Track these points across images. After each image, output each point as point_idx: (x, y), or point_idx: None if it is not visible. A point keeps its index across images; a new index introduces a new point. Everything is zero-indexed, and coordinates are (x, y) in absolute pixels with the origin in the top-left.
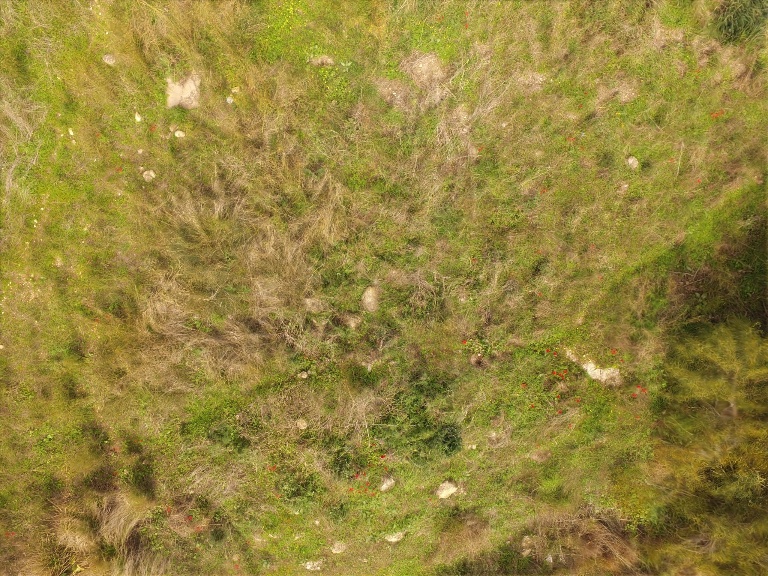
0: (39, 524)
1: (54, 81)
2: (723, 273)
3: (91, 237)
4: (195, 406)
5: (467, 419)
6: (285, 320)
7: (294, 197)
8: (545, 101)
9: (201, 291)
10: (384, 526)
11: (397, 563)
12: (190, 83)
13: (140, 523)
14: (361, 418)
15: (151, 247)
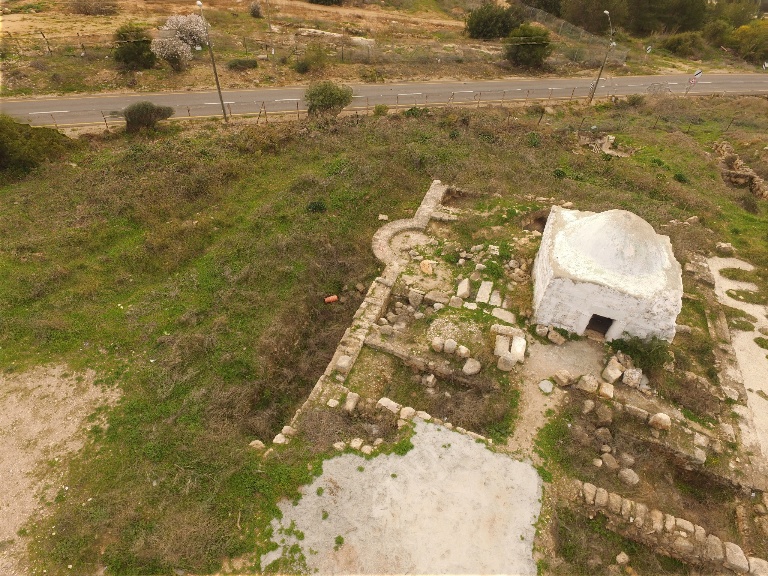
0: None
1: None
2: (7, 180)
3: None
4: None
5: None
6: None
7: None
8: None
9: None
10: None
11: None
12: None
13: None
14: None
15: None
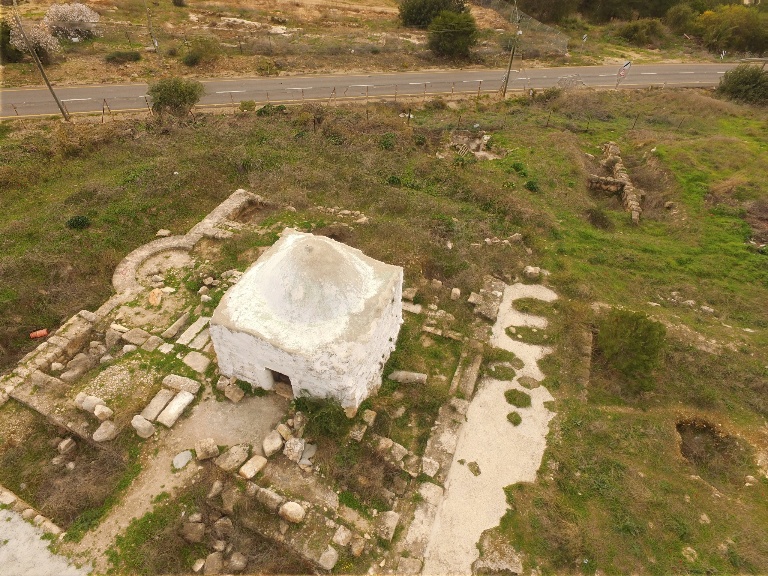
0: None
1: None
2: None
3: None
4: None
5: None
6: None
7: None
8: None
9: None
10: None
11: None
12: None
13: None
14: None
15: None
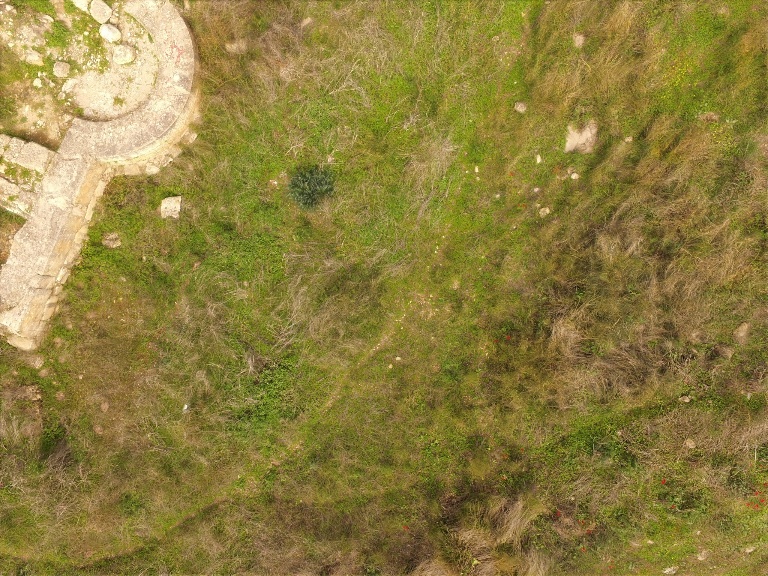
0: (439, 520)
1: (467, 123)
2: None
3: (488, 264)
4: (577, 421)
5: None
6: (673, 349)
7: (691, 240)
8: None
9: (603, 320)
10: (752, 538)
11: (732, 571)
12: (587, 131)
13: None
14: (751, 441)
15: (552, 277)
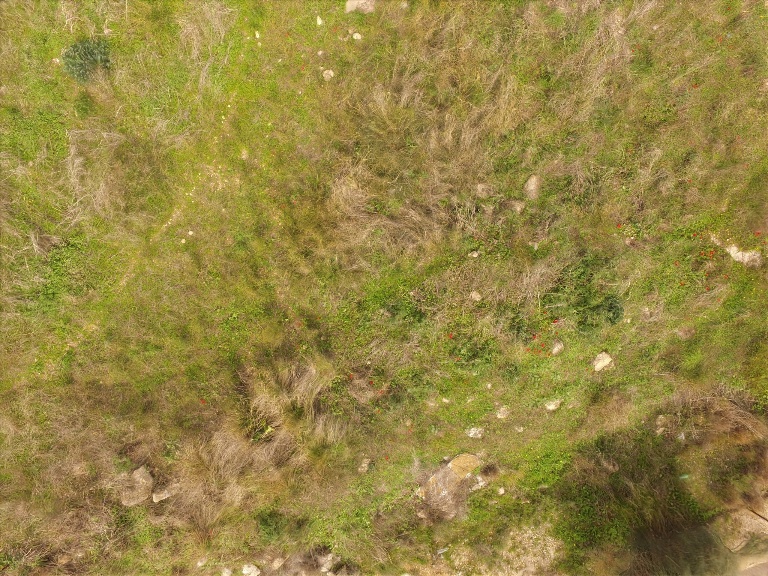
0: (232, 390)
1: None
2: None
3: (274, 132)
4: (371, 285)
5: (625, 293)
6: (458, 204)
7: (469, 90)
8: (694, 5)
9: (383, 176)
10: (547, 391)
11: (546, 436)
12: None
13: (322, 391)
14: (533, 288)
15: (334, 138)
